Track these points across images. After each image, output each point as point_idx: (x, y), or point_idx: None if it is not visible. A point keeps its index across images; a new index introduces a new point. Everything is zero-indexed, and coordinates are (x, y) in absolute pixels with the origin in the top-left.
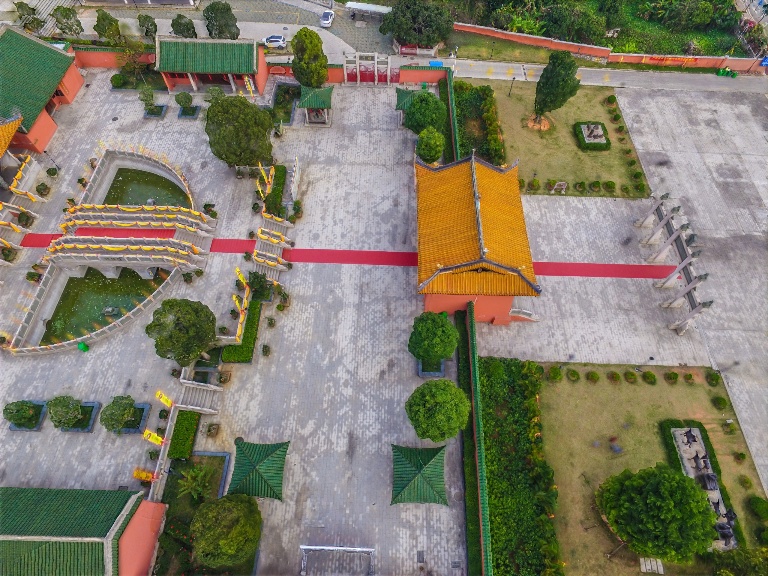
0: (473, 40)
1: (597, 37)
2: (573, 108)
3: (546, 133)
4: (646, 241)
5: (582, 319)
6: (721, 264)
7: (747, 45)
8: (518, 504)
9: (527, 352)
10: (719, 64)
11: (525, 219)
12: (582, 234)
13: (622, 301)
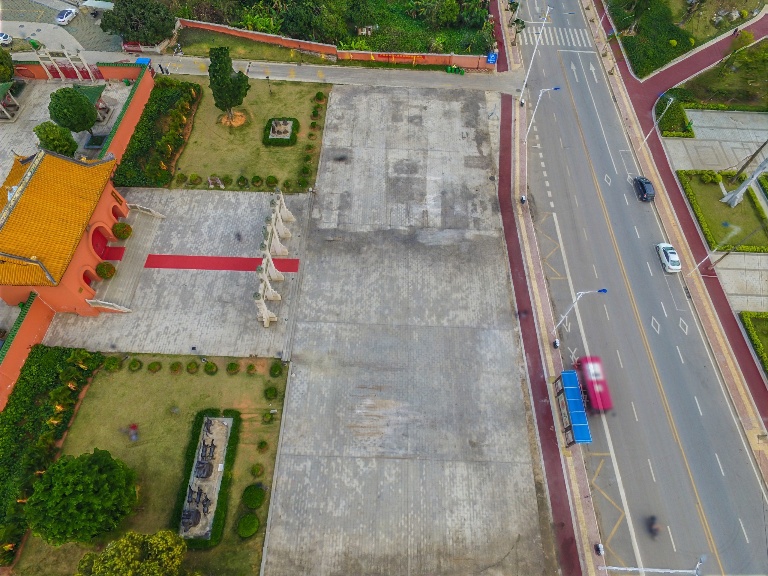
0: (207, 38)
1: (331, 35)
2: (279, 104)
3: (237, 129)
4: (278, 235)
5: (175, 311)
6: (349, 258)
7: (489, 43)
8: (6, 490)
9: (102, 343)
10: (448, 61)
11: (170, 213)
12: (220, 228)
13: (225, 293)
